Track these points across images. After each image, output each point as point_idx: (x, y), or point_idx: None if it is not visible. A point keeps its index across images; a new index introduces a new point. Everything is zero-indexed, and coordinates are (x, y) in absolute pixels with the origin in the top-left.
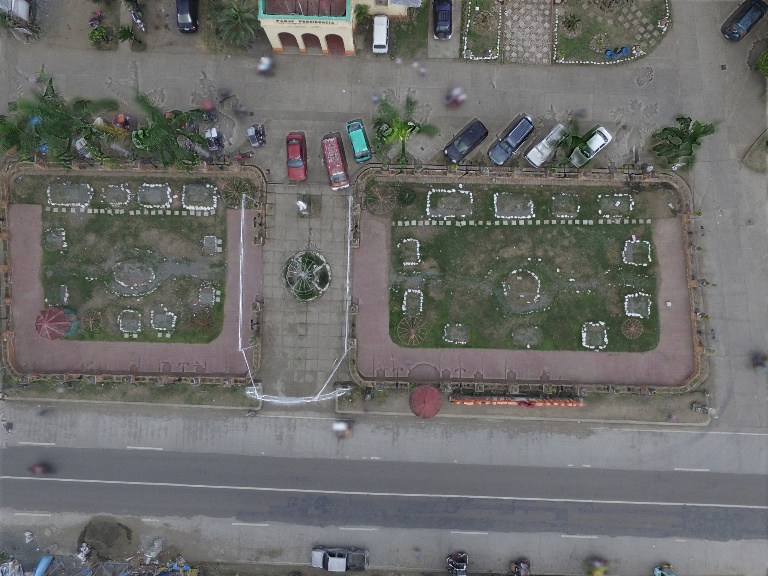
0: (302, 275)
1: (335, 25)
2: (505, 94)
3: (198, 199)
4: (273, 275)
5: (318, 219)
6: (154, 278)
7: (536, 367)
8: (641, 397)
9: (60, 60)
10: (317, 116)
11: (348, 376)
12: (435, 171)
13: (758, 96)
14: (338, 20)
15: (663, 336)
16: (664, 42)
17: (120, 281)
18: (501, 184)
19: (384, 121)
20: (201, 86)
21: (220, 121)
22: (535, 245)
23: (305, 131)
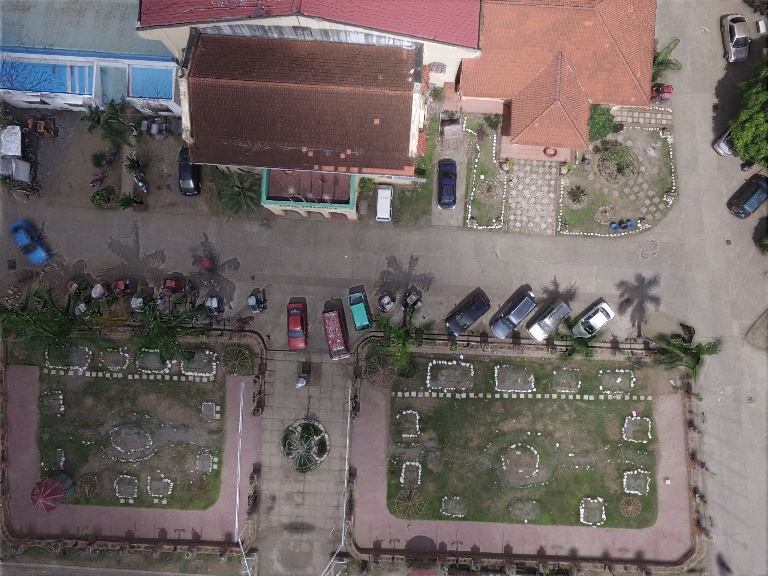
0: (300, 451)
1: (338, 209)
2: (508, 264)
3: (197, 366)
4: (271, 443)
5: (317, 387)
6: (151, 444)
7: (533, 541)
8: (638, 575)
9: (60, 218)
10: (319, 281)
11: (344, 547)
12: (436, 342)
13: (762, 273)
14: (342, 207)
15: (661, 513)
16: (669, 215)
17: (117, 446)
18: (502, 356)
19: (386, 288)
20: (202, 248)
21: (221, 284)
22: (535, 419)
23: (306, 296)
